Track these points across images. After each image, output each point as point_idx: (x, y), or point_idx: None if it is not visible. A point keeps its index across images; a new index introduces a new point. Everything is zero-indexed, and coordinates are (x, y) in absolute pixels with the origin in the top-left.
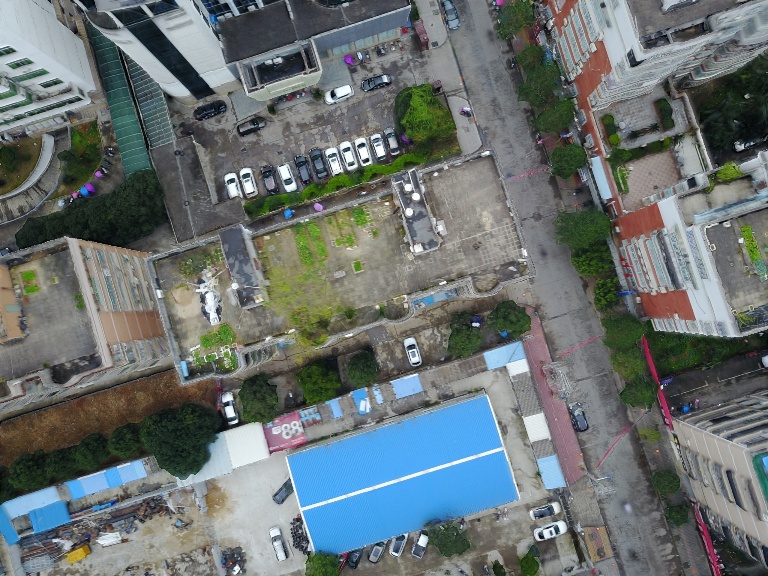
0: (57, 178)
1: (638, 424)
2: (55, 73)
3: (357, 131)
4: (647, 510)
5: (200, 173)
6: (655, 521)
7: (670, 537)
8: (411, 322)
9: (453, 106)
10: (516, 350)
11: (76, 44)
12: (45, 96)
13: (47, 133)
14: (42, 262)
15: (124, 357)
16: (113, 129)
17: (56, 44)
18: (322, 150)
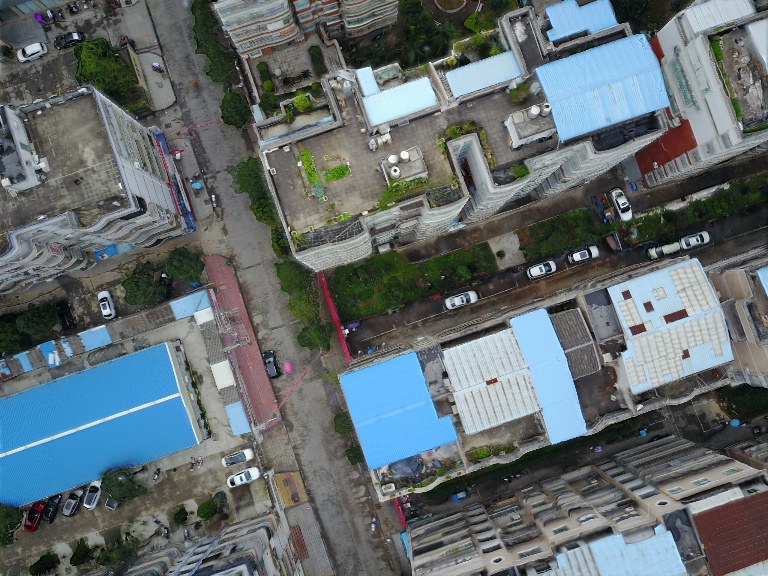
0: None
1: (330, 369)
2: None
3: (52, 88)
4: (340, 454)
5: None
6: (348, 464)
7: (363, 479)
8: (107, 276)
9: (147, 62)
10: (202, 299)
11: None
12: None
13: None
14: None
15: None
16: None
17: None
18: None
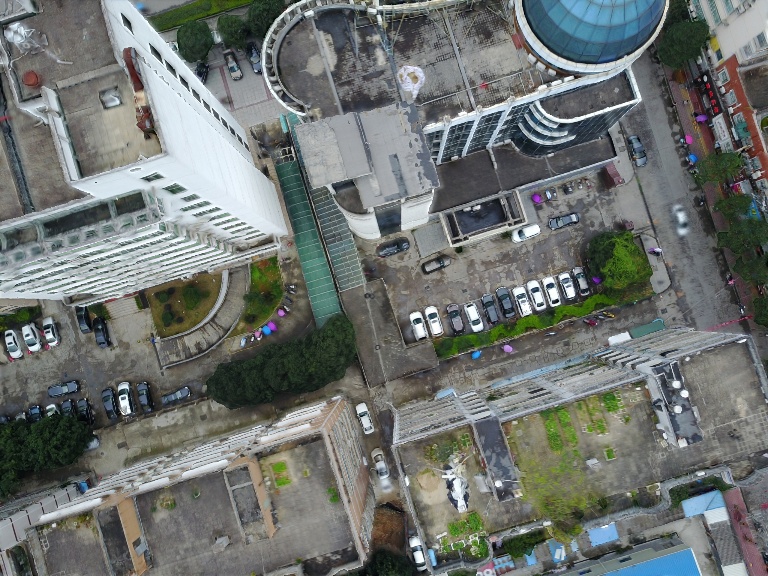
0: (233, 313)
1: None
2: (264, 230)
3: (543, 269)
4: None
5: (391, 317)
6: None
7: None
8: None
9: None
10: (714, 498)
11: (273, 192)
12: (245, 247)
13: (225, 269)
14: (292, 453)
15: (366, 542)
16: (295, 266)
17: (269, 204)
18: (508, 289)
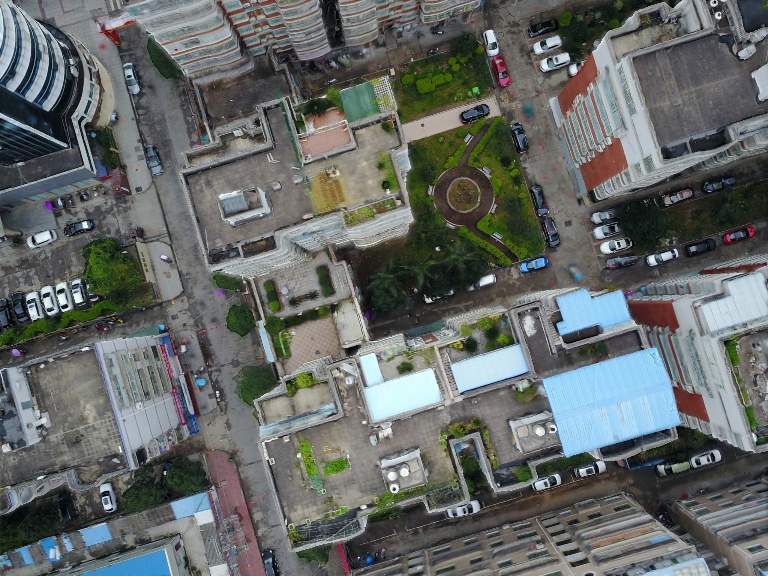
0: None
1: (329, 571)
2: None
3: (61, 275)
4: None
5: None
6: None
7: None
8: None
9: (155, 251)
10: (203, 500)
11: None
12: None
13: None
14: None
15: None
16: None
17: None
18: (25, 294)
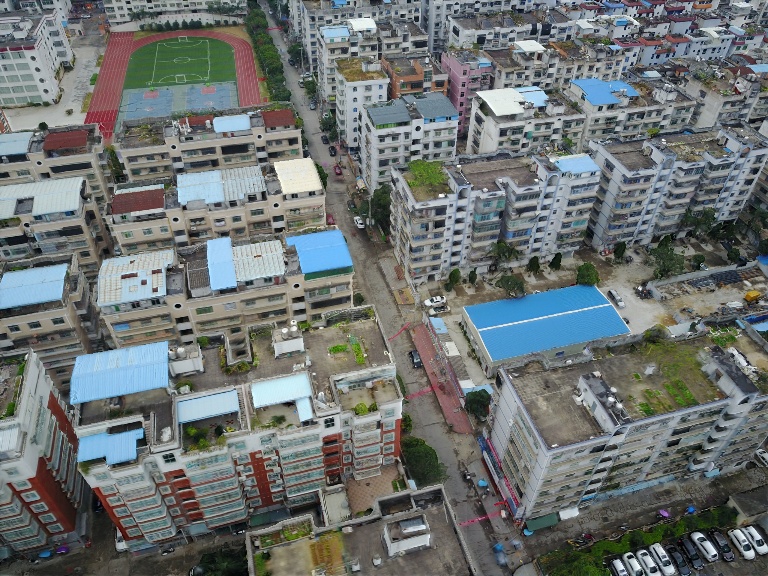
0: None
1: None
2: None
3: None
4: None
5: None
6: None
7: None
8: None
9: None
10: None
11: None
12: None
13: None
14: None
15: None
16: None
17: None
18: (678, 575)
